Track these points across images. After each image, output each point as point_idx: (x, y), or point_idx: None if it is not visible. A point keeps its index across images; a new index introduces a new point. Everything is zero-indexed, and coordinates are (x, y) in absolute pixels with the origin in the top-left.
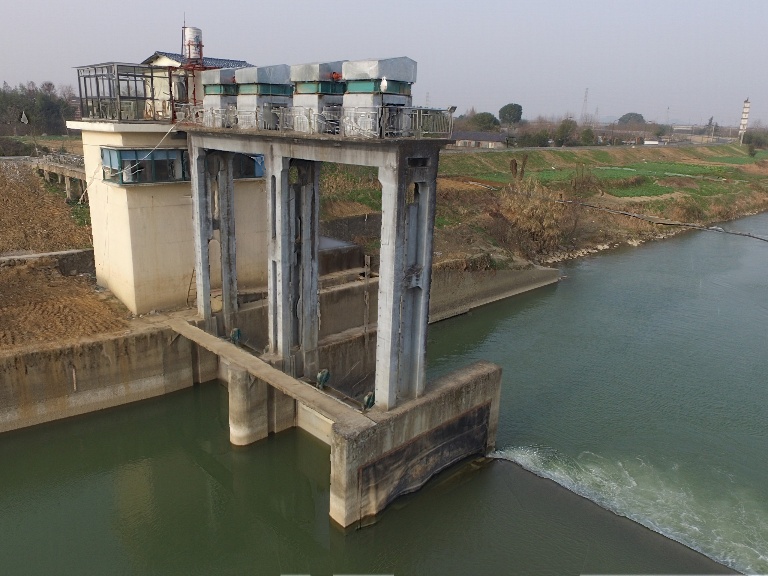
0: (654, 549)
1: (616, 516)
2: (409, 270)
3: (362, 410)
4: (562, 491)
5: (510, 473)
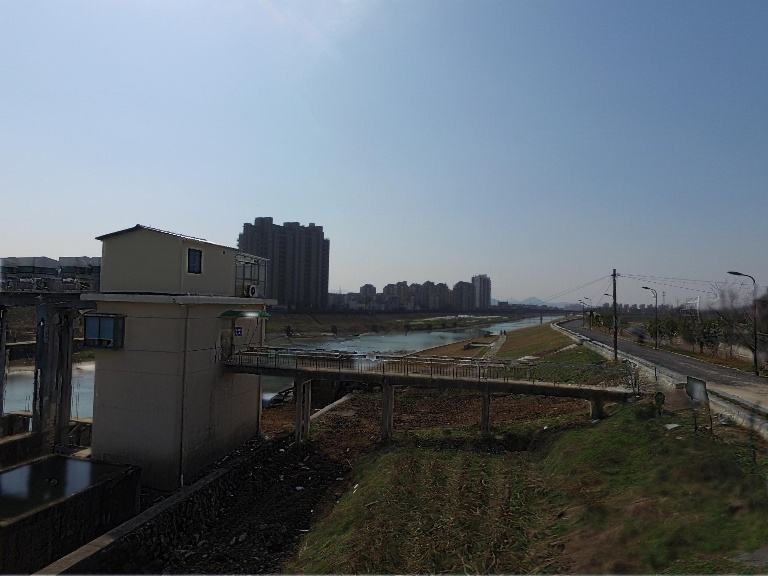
0: None
1: None
2: None
3: (4, 436)
4: None
5: None
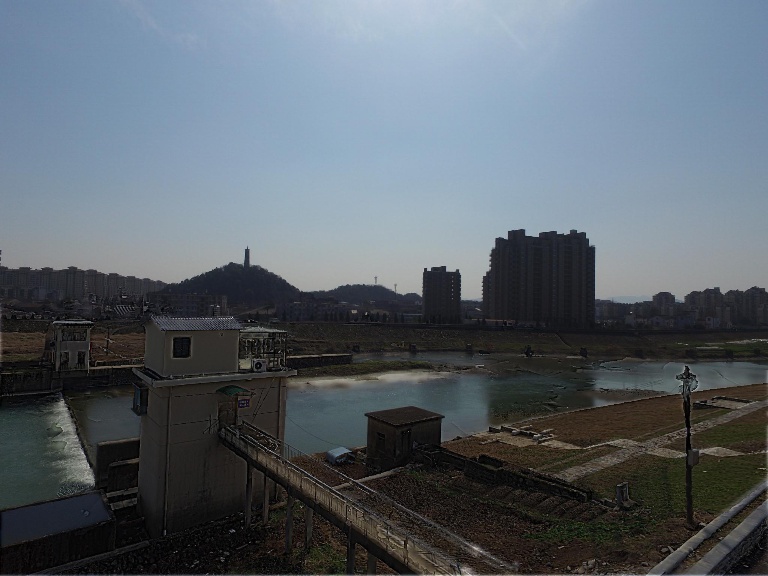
0: None
1: None
2: None
3: None
4: None
5: None
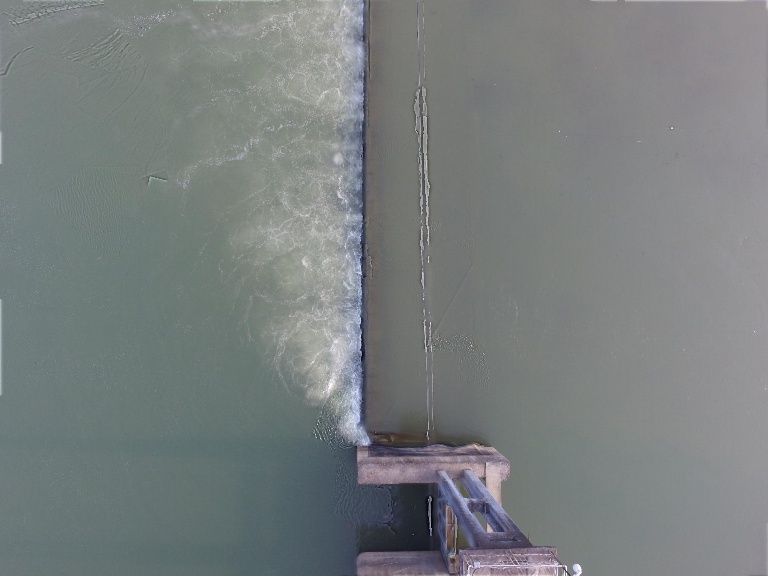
0: (378, 333)
1: (371, 357)
2: (473, 511)
3: None
4: (371, 389)
5: (378, 421)
